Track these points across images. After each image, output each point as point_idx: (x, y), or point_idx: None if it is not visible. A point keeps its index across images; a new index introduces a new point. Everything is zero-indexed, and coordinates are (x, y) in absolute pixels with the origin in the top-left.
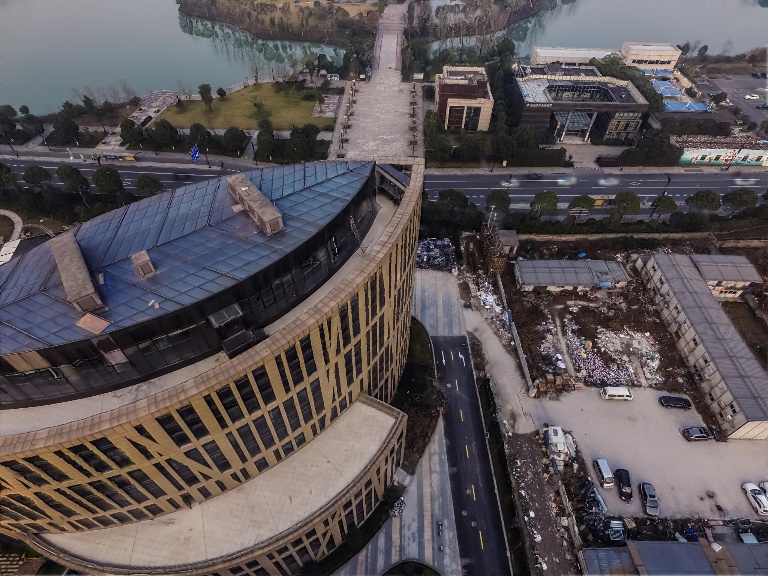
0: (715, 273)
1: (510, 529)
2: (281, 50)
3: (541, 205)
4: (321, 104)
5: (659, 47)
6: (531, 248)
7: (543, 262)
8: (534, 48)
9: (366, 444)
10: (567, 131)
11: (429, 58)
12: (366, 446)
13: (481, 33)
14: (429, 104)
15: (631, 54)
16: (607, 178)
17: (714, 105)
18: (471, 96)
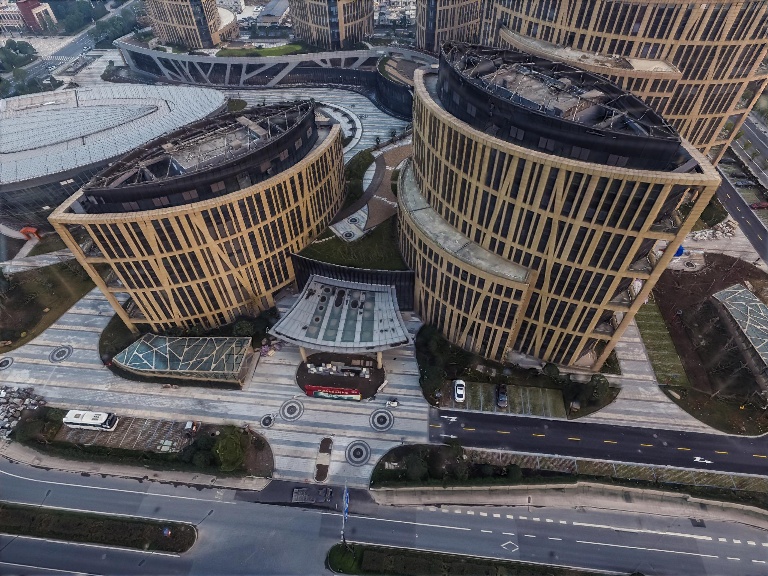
0: None
1: (248, 30)
2: None
3: None
4: None
5: None
6: None
7: None
8: None
9: (218, 8)
10: None
11: None
12: (219, 8)
13: None
14: (5, 34)
15: None
16: None
17: None
18: (38, 4)
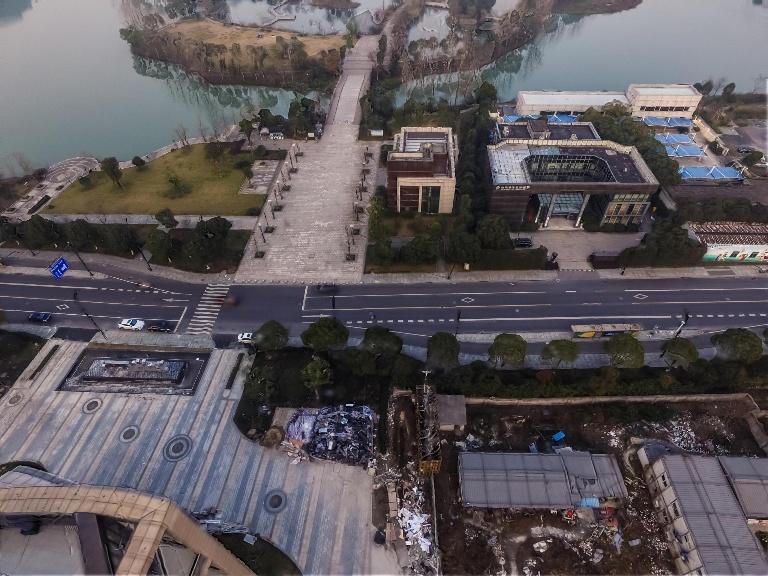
0: (761, 500)
1: None
2: (235, 95)
3: (501, 357)
4: (249, 178)
5: (674, 90)
6: (485, 424)
7: (498, 457)
8: (520, 93)
9: None
10: (553, 213)
11: (393, 108)
12: None
13: (463, 69)
14: (385, 172)
15: (638, 100)
16: (603, 287)
17: (746, 168)
18: (426, 174)
